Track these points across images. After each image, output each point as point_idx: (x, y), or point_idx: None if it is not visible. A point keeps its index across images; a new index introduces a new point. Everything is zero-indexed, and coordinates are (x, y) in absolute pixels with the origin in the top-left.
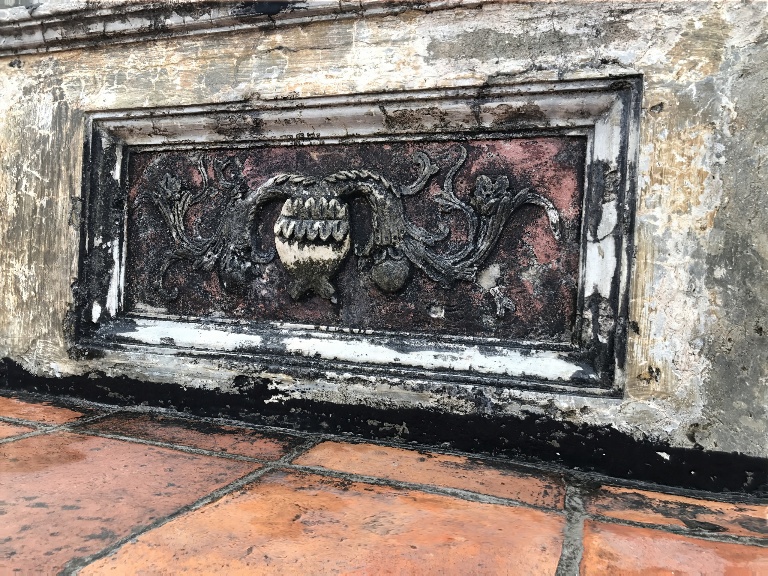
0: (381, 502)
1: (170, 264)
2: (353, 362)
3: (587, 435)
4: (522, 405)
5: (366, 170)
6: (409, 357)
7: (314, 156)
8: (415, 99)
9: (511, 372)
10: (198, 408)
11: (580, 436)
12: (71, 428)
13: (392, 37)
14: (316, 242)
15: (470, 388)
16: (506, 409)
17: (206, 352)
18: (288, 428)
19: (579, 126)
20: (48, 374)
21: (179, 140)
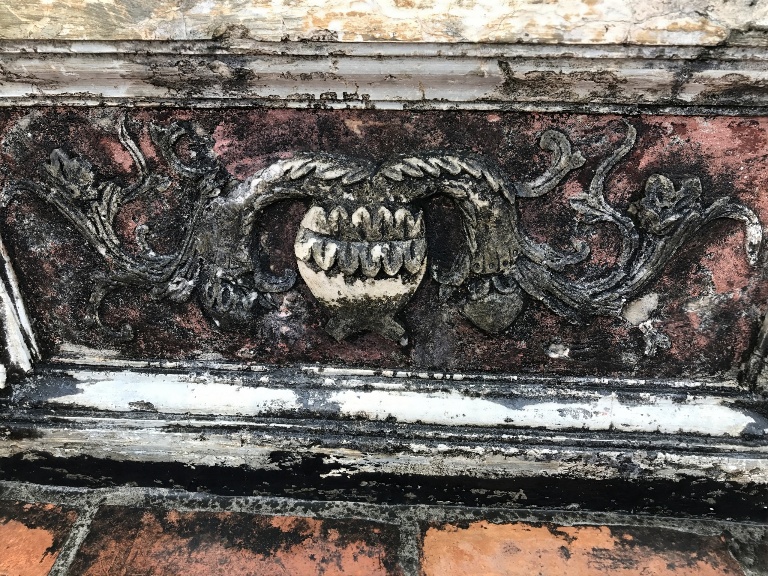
0: None
1: (106, 292)
2: (446, 426)
3: (751, 492)
4: (679, 469)
5: (456, 158)
6: (525, 416)
7: (353, 127)
8: (575, 56)
9: (665, 430)
10: (219, 487)
11: (743, 493)
12: None
13: None
14: (376, 275)
15: (615, 456)
16: (658, 473)
17: (215, 423)
18: (360, 502)
19: None
20: None
21: (67, 92)
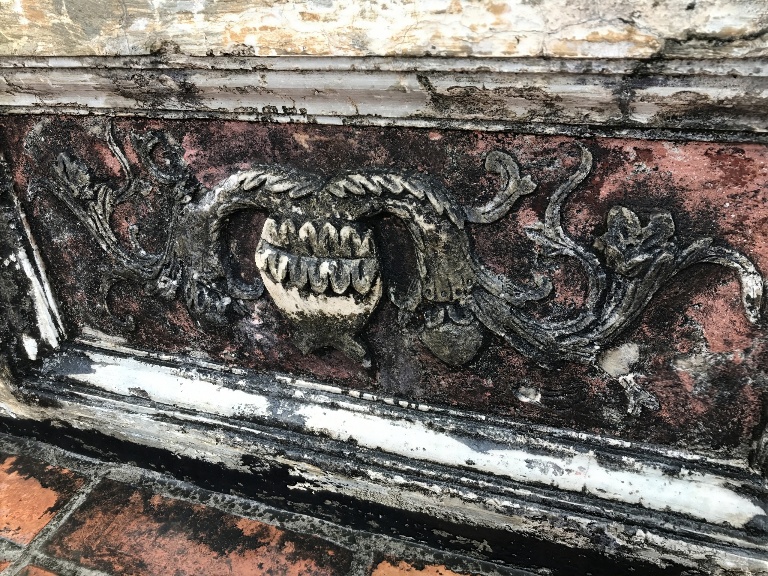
0: None
1: (111, 285)
2: (405, 457)
3: None
4: (664, 554)
5: (399, 177)
6: (488, 461)
7: (301, 141)
8: (493, 71)
9: (648, 504)
10: (202, 480)
11: None
12: (43, 552)
13: None
14: (327, 292)
15: (584, 523)
16: (638, 553)
17: (195, 418)
18: (325, 520)
19: None
20: None
21: (61, 102)
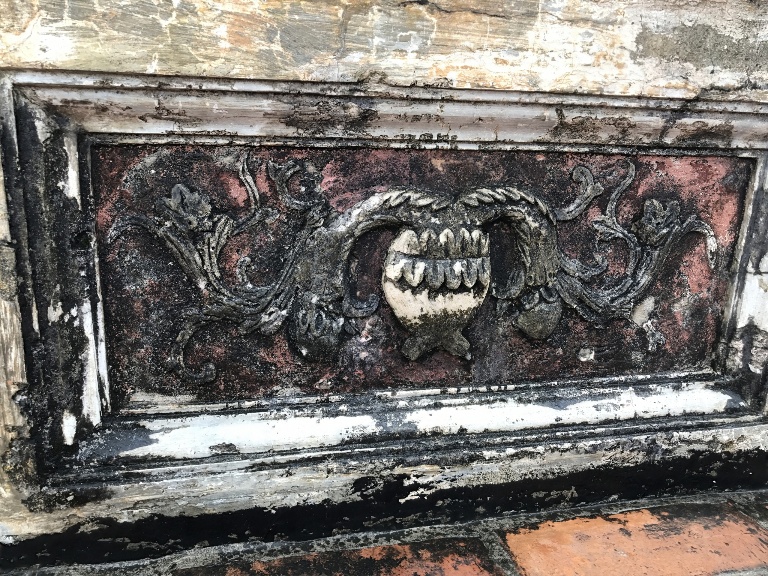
0: None
1: (196, 330)
2: (508, 431)
3: (740, 460)
4: (690, 445)
5: (515, 189)
6: (571, 414)
7: (438, 164)
8: (607, 105)
9: (674, 412)
10: (298, 531)
11: (734, 462)
12: None
13: (593, 15)
14: None
15: (644, 439)
16: (675, 452)
17: (301, 456)
18: (435, 525)
19: (755, 148)
20: None
21: (205, 130)
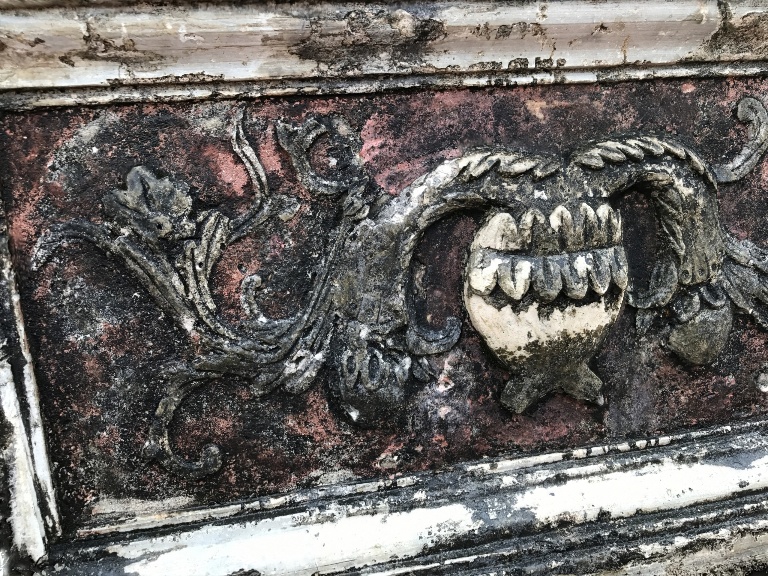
0: None
1: (185, 395)
2: (672, 510)
3: None
4: None
5: (655, 138)
6: (760, 474)
7: (535, 109)
8: None
9: None
10: None
11: None
12: None
13: None
14: (578, 299)
15: None
16: None
17: None
18: None
19: None
20: None
21: (171, 74)
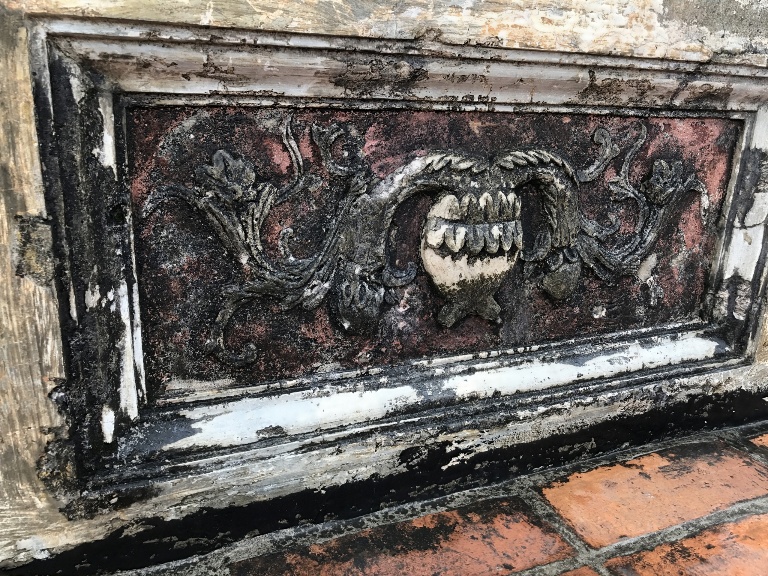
0: (755, 560)
1: (237, 308)
2: (537, 390)
3: (726, 400)
4: (688, 390)
5: (545, 151)
6: (590, 369)
7: (474, 127)
8: None
9: (674, 361)
10: (347, 509)
11: (722, 403)
12: None
13: None
14: None
15: (652, 388)
16: (676, 398)
17: (349, 432)
18: (473, 488)
19: (744, 110)
20: (13, 562)
21: (251, 90)
